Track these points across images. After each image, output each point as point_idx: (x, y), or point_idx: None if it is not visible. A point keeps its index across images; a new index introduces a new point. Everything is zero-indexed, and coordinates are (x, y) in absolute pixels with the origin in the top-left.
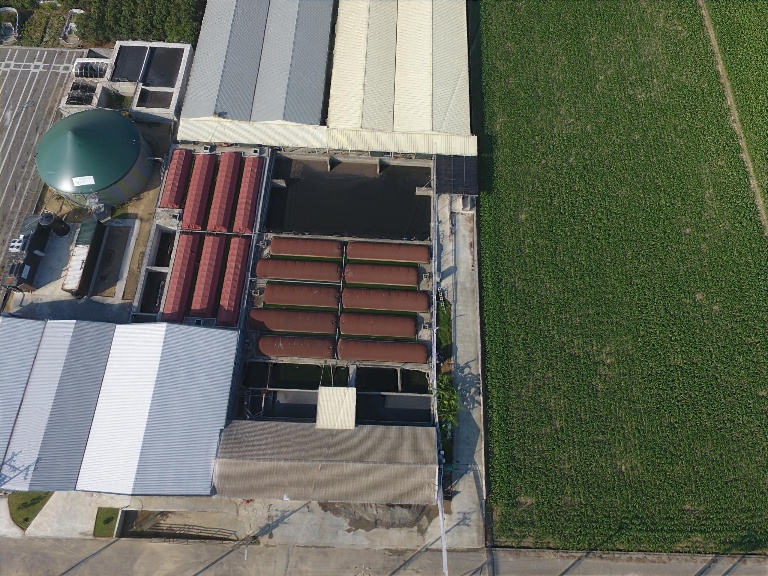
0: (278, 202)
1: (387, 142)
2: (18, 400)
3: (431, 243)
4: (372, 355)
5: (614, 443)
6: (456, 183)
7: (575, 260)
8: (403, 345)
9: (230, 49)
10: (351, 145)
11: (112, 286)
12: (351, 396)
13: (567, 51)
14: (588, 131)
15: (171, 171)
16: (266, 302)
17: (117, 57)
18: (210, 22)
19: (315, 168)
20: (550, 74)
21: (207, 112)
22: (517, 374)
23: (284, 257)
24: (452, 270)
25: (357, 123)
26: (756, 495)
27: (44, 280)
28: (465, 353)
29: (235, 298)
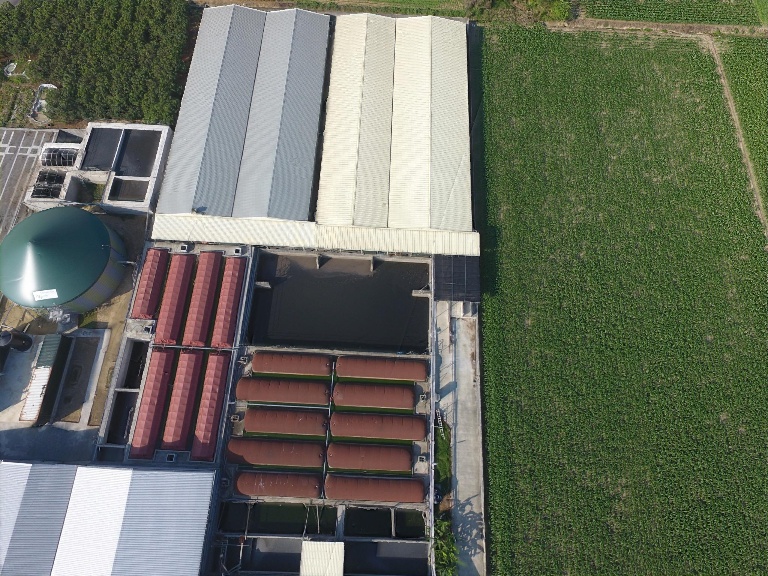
0: (262, 304)
1: (381, 240)
2: None
3: (429, 357)
4: (363, 495)
5: None
6: (456, 288)
7: (587, 374)
8: (397, 483)
9: (211, 133)
10: (342, 244)
11: (77, 409)
12: (338, 552)
13: (576, 128)
14: (600, 221)
15: (144, 276)
16: (246, 430)
17: (88, 141)
18: (190, 101)
19: (303, 265)
20: (558, 154)
21: (185, 207)
22: (523, 513)
23: (267, 375)
24: (452, 386)
25: (348, 219)
26: None
27: (2, 404)
28: (466, 487)
29: (212, 428)
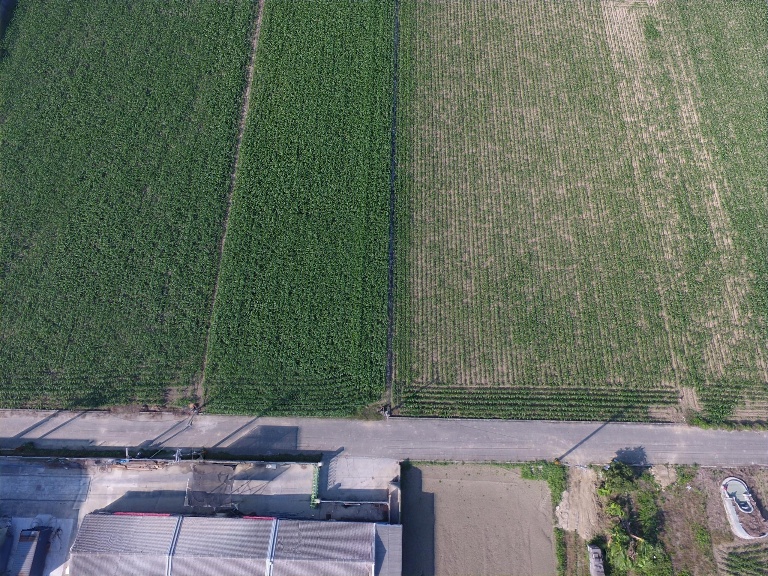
0: None
1: None
2: None
3: None
4: None
5: (2, 315)
6: None
7: (36, 158)
8: None
9: None
10: None
11: None
12: None
13: None
14: None
15: None
16: None
17: None
18: None
19: None
20: None
21: None
22: None
23: None
24: None
25: None
26: (118, 359)
27: None
28: None
29: None
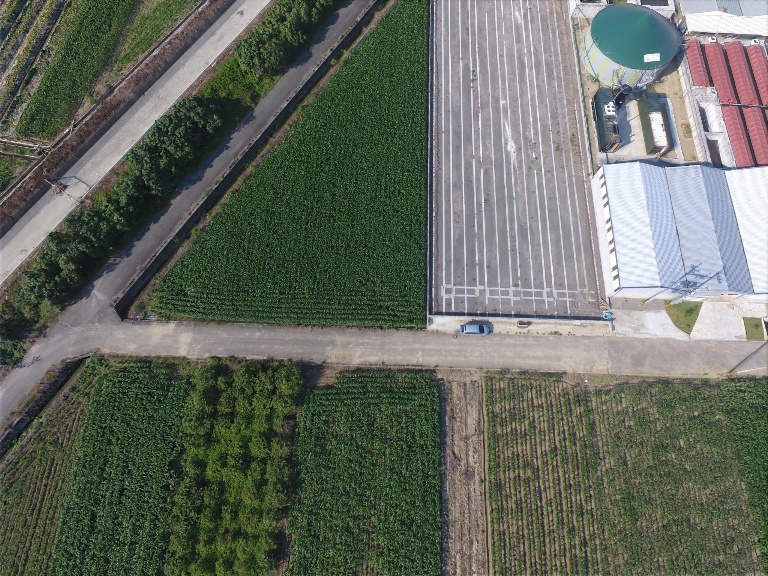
0: None
1: None
2: (674, 227)
3: None
4: None
5: None
6: None
7: None
8: None
9: None
10: None
11: (671, 150)
12: None
13: None
14: None
15: (695, 56)
16: None
17: None
18: None
19: None
20: None
21: (711, 7)
22: None
23: None
24: None
25: None
26: None
27: None
28: None
29: None
